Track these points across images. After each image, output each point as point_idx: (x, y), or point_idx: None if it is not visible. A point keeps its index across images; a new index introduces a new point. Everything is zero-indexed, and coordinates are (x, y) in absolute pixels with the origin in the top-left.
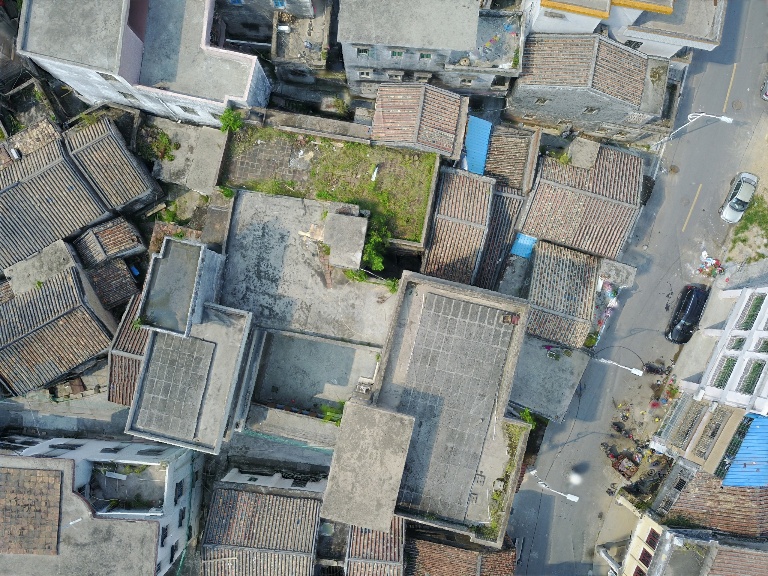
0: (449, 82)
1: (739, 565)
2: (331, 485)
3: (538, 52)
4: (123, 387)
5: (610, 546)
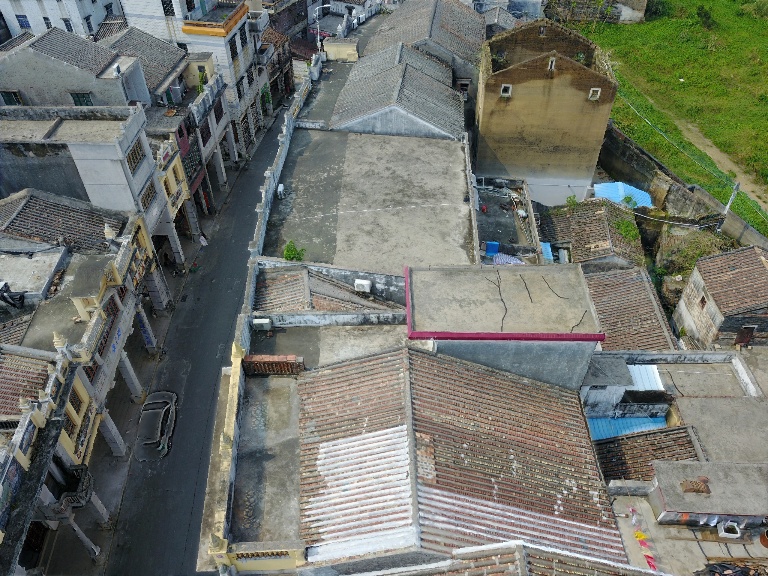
0: None
1: (411, 3)
2: None
3: None
4: None
5: None
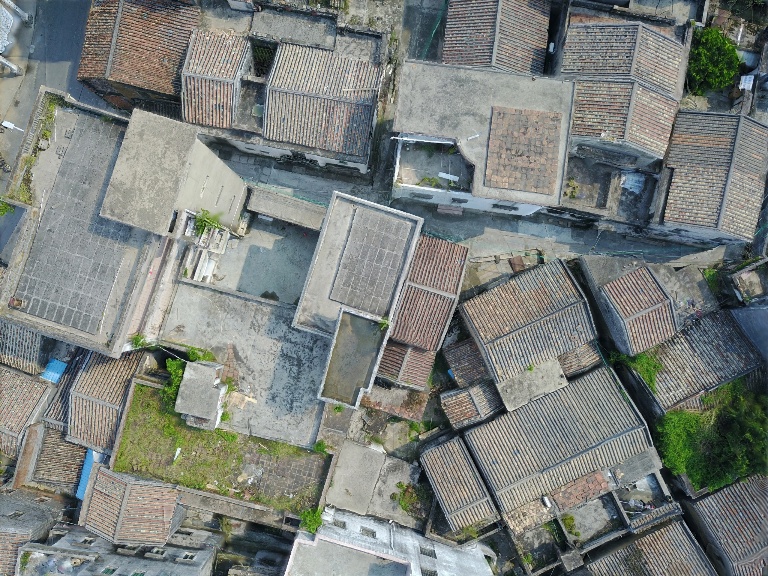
0: (107, 542)
1: None
2: (186, 157)
3: (4, 566)
4: (451, 261)
5: (10, 74)
